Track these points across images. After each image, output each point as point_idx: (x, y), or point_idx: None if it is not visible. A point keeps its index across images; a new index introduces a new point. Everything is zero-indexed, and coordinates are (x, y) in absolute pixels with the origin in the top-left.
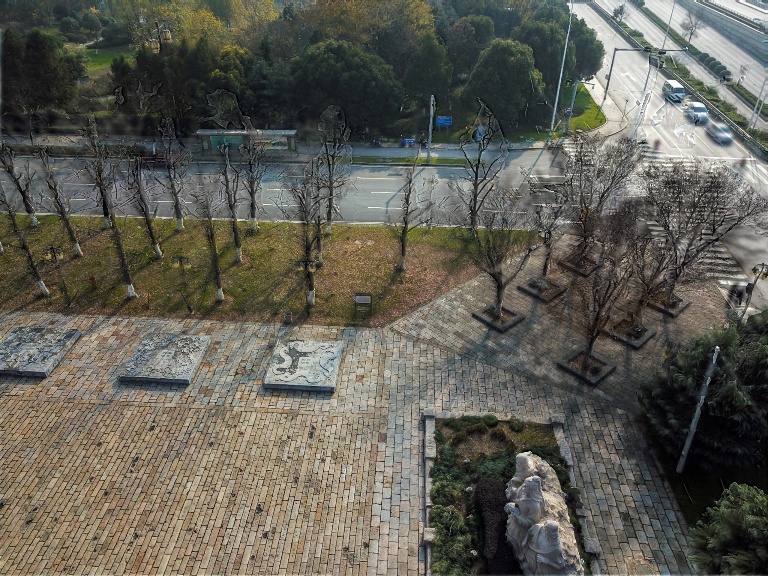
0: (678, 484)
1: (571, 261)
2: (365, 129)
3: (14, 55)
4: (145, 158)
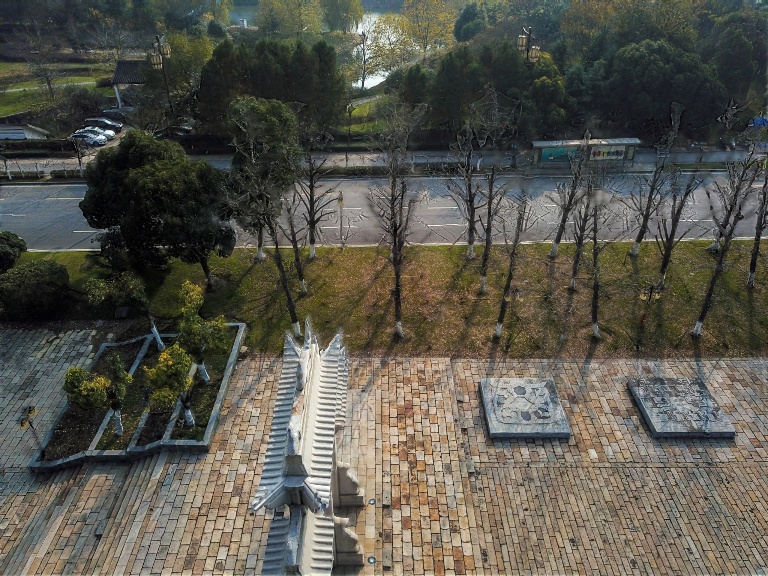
0: None
1: None
2: (668, 133)
3: (309, 70)
4: (474, 175)
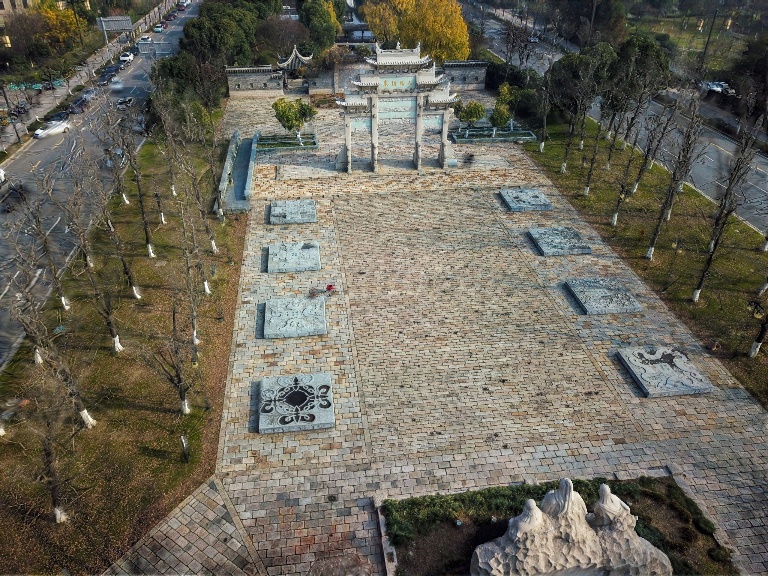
0: None
1: None
2: None
3: None
4: None
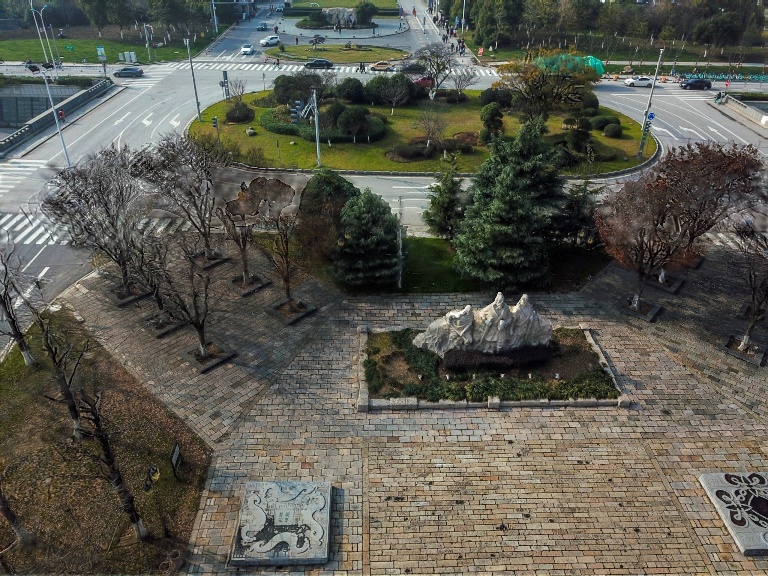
0: (411, 289)
1: (123, 297)
2: None
3: None
4: None
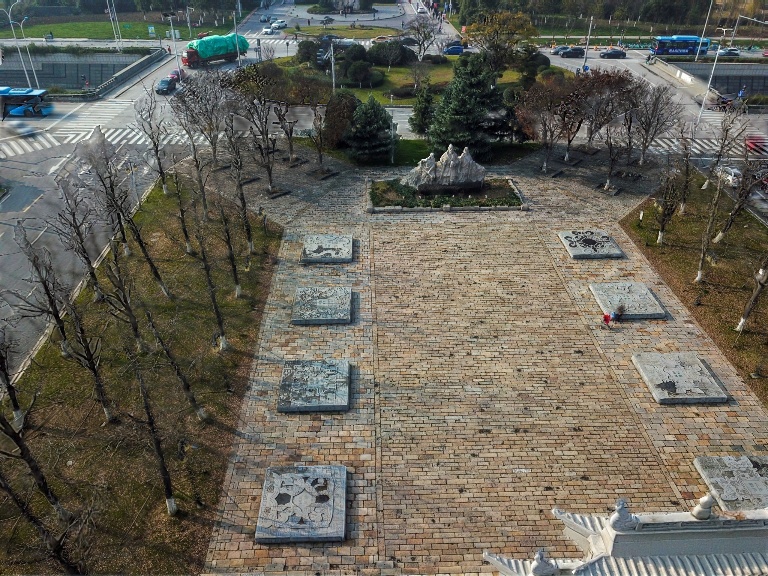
0: (400, 164)
1: None
2: None
3: None
4: None
